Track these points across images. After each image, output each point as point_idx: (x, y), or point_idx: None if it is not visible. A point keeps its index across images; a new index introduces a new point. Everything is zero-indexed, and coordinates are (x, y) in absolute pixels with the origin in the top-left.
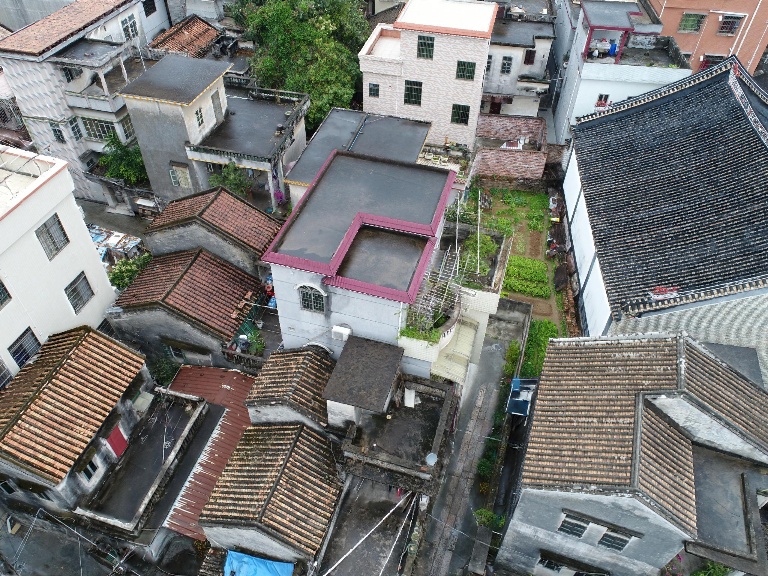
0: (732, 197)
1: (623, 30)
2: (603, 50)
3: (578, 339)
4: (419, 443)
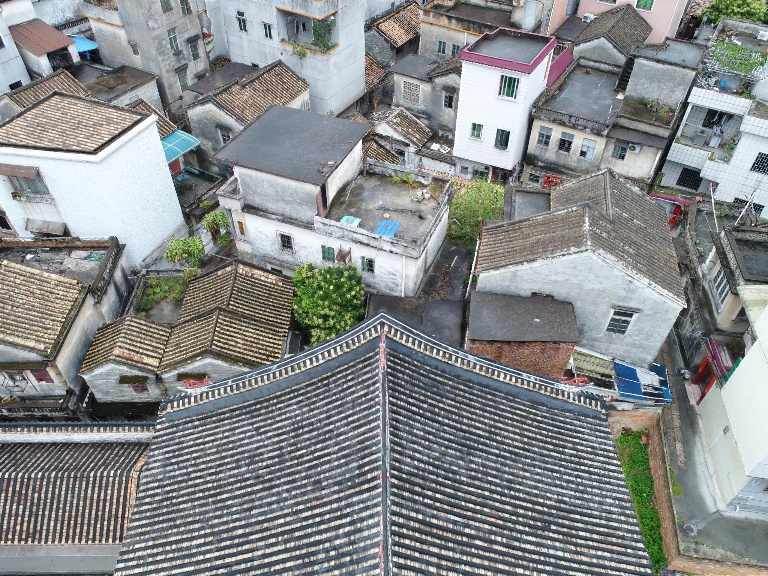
0: (469, 572)
1: None
2: None
3: (665, 290)
4: (742, 257)
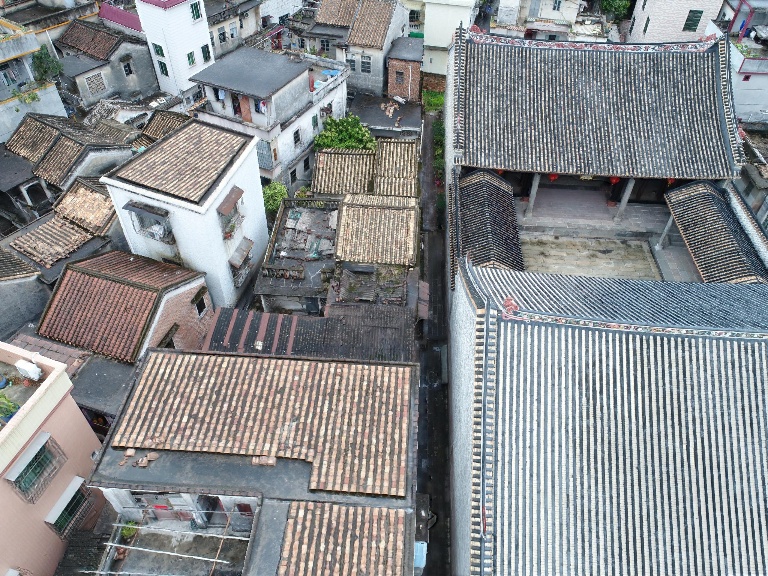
0: None
1: (748, 6)
2: (760, 35)
3: None
4: None
